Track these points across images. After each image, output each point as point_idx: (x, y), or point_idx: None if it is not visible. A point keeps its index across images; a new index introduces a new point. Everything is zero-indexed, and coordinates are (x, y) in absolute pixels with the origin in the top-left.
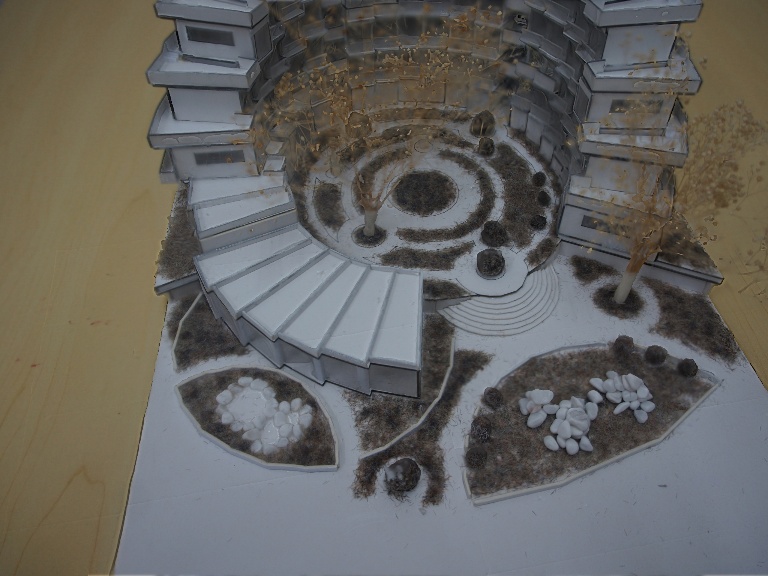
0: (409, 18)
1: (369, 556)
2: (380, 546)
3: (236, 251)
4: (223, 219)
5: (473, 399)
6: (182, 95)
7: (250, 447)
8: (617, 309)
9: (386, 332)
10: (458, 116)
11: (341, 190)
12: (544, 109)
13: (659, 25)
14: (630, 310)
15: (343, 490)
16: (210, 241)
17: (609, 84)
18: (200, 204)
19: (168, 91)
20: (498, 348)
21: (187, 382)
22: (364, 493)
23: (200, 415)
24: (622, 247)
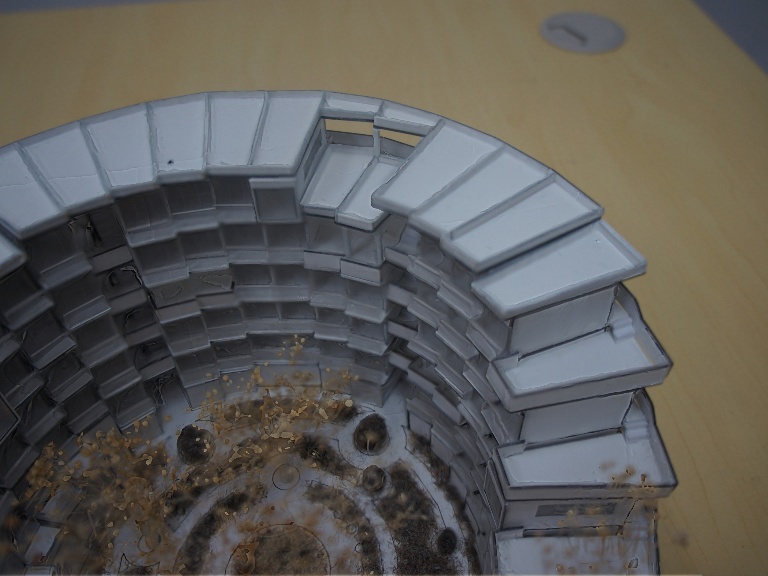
0: (254, 303)
1: None
2: None
3: None
4: None
5: None
6: None
7: None
8: None
9: None
10: (339, 413)
11: None
12: (450, 433)
13: (603, 397)
14: None
15: None
16: None
17: (531, 493)
18: None
19: None
20: None
21: None
22: None
23: None
24: None
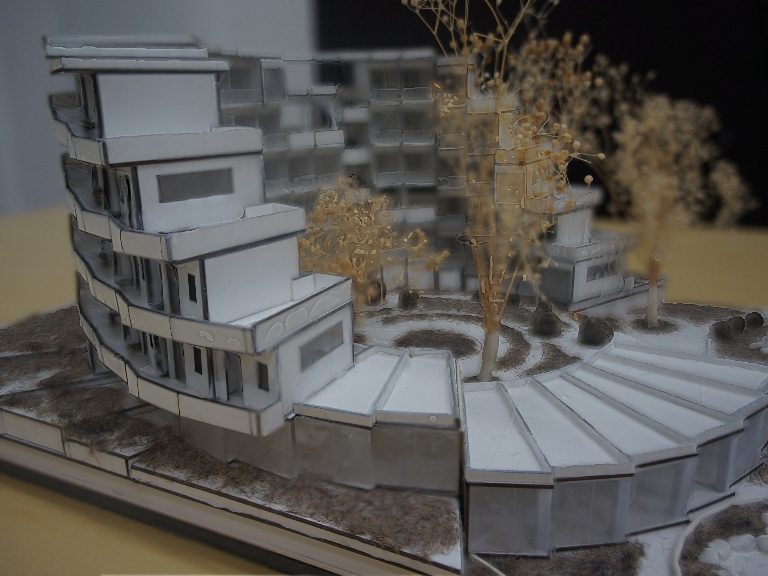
0: None
1: None
2: None
3: (471, 442)
4: (428, 404)
5: None
6: (226, 268)
7: None
8: (665, 328)
9: None
10: None
11: None
12: (425, 245)
13: None
14: (669, 325)
15: None
16: None
17: (530, 154)
18: None
19: (202, 268)
20: None
21: None
22: None
23: None
24: (613, 287)
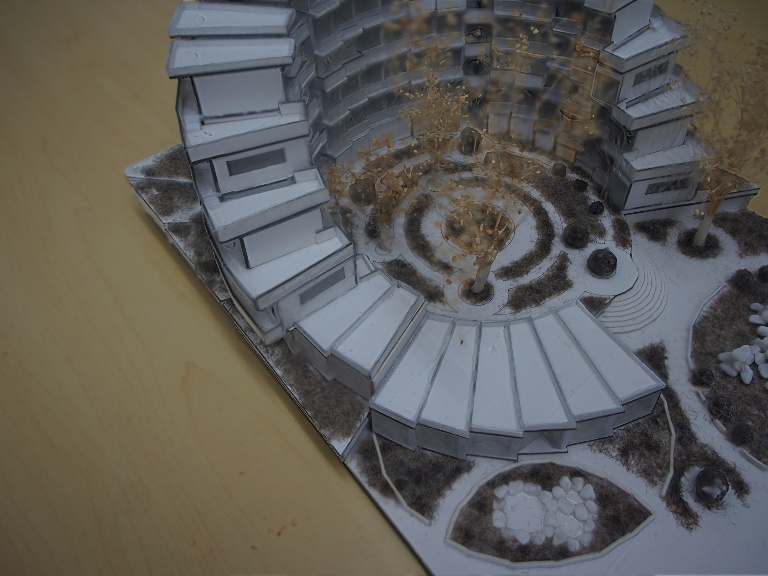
0: (372, 66)
1: (748, 572)
2: (747, 558)
3: (397, 372)
4: (371, 347)
5: (686, 388)
6: (259, 239)
7: (568, 549)
8: (705, 251)
9: (603, 370)
10: (437, 143)
11: (407, 262)
12: (530, 105)
13: None
14: (714, 247)
15: (675, 532)
16: (379, 376)
17: (635, 62)
18: (336, 344)
19: (242, 241)
20: (660, 333)
21: (453, 528)
22: (693, 522)
23: (495, 551)
24: (680, 198)
